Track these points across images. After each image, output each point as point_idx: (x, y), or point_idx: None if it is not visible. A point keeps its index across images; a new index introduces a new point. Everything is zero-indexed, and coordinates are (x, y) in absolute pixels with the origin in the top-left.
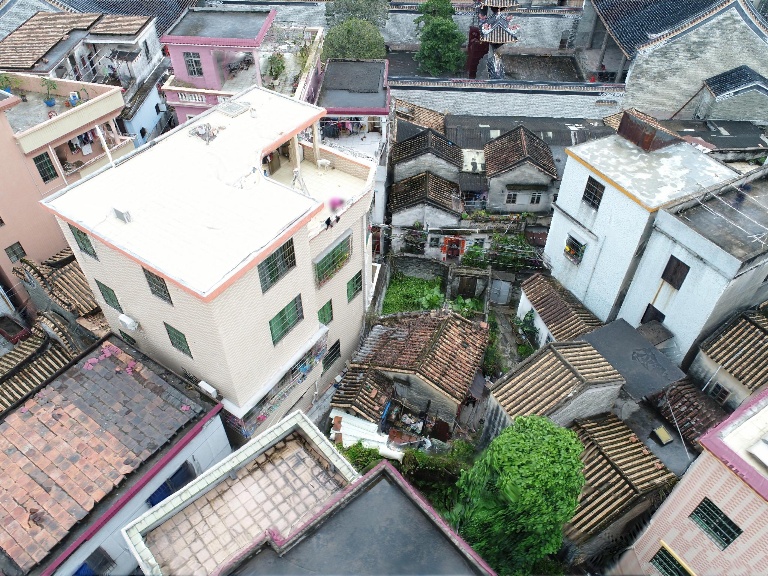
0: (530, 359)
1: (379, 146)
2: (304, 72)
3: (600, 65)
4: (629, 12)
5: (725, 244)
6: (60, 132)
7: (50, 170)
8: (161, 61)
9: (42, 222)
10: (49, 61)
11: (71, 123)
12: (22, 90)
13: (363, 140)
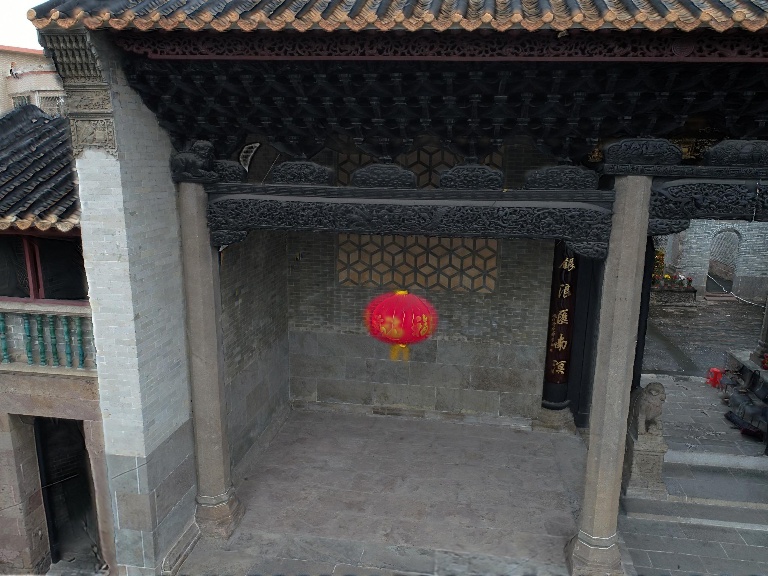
0: None
1: None
2: None
3: (763, 345)
4: None
5: None
6: None
7: None
8: None
9: None
10: None
11: None
12: None
13: None
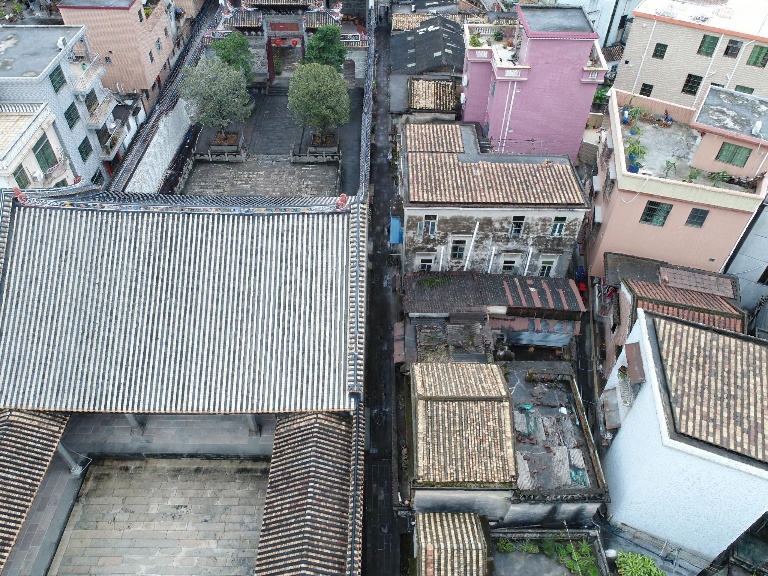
0: None
1: None
2: None
3: None
4: None
5: None
6: None
7: None
8: None
9: None
10: None
11: None
12: None
13: None
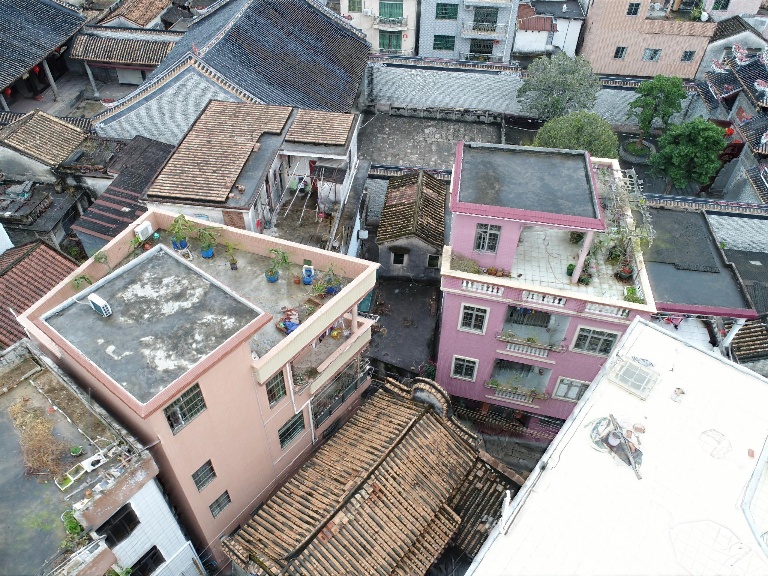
0: None
1: (723, 354)
2: (636, 250)
3: None
4: None
5: None
6: (303, 342)
7: (280, 390)
8: (356, 167)
9: (256, 456)
10: (245, 188)
11: (317, 326)
12: (225, 246)
13: (678, 329)
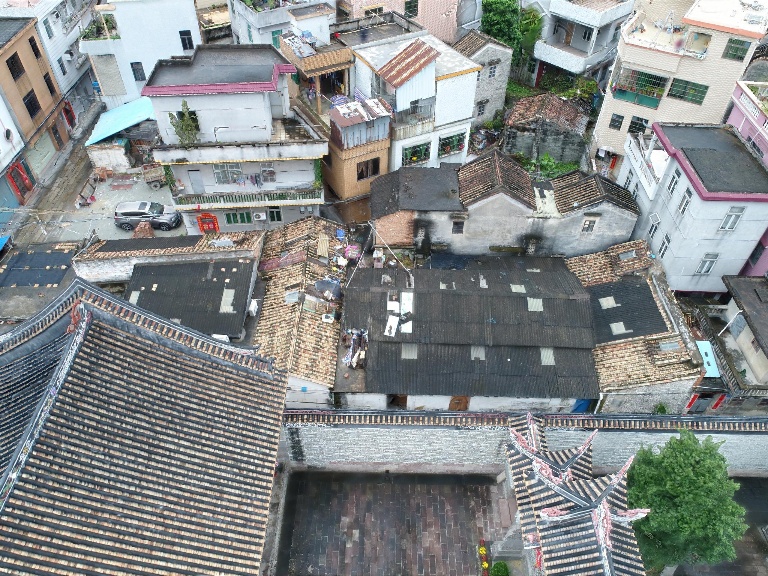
0: (498, 42)
1: None
2: None
3: None
4: (188, 573)
5: (389, 31)
6: None
7: None
8: None
9: None
10: None
11: None
12: None
13: None
